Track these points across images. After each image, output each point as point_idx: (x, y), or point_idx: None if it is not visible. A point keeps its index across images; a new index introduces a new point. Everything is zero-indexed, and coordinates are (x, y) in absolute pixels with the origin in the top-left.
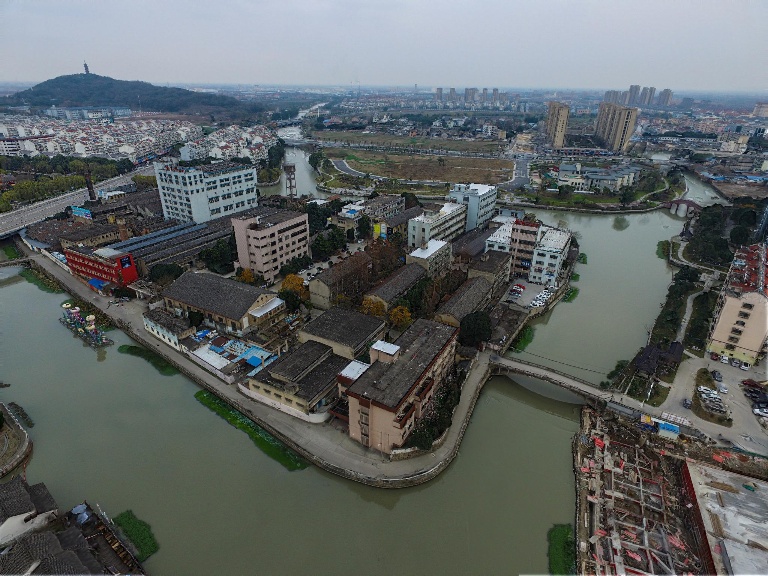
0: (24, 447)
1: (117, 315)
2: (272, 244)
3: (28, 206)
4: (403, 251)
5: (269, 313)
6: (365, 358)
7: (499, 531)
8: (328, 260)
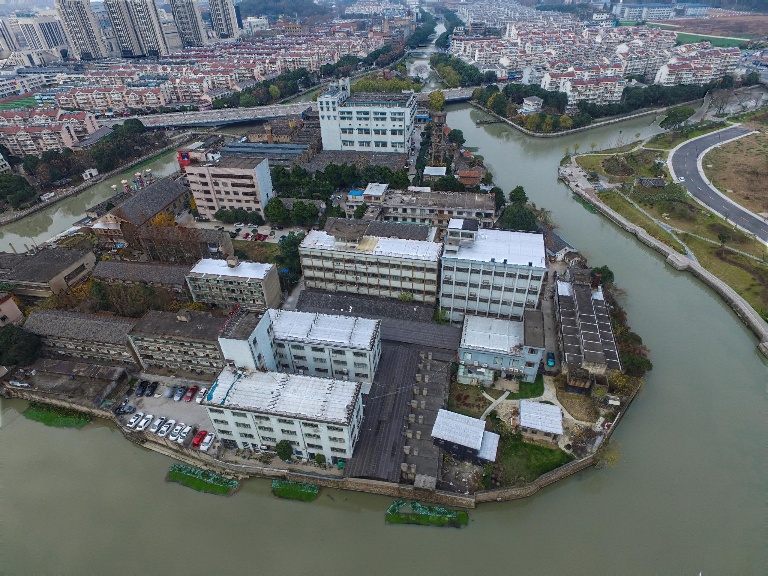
0: (1, 221)
1: None
2: (204, 184)
3: None
4: (296, 263)
5: (105, 230)
6: None
7: None
8: (278, 229)
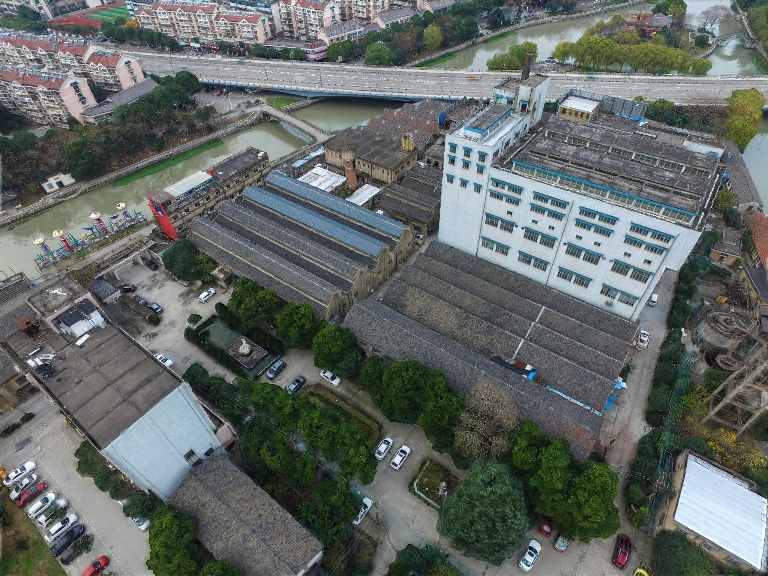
0: None
1: (101, 253)
2: None
3: (530, 72)
4: None
5: None
6: None
7: None
8: None
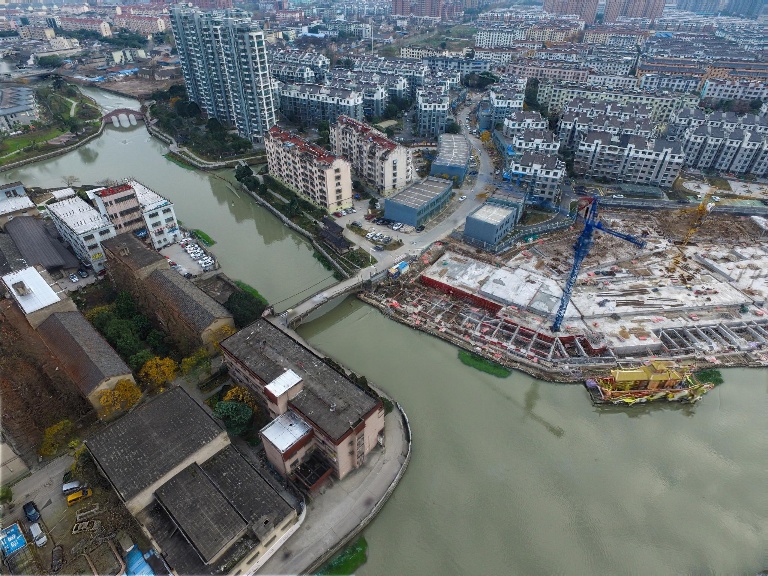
0: None
1: None
2: None
3: None
4: None
5: None
6: (237, 427)
7: (460, 391)
8: None
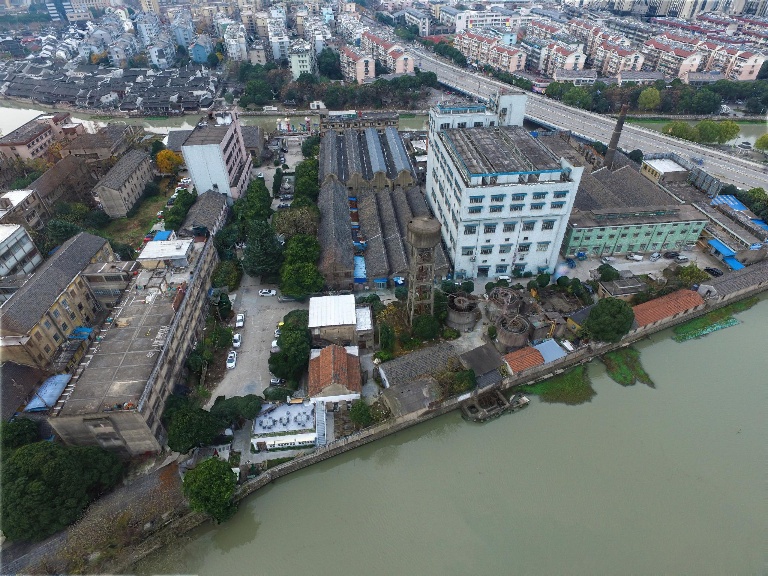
0: None
1: None
2: None
3: (697, 145)
4: None
5: None
6: None
7: None
8: None
